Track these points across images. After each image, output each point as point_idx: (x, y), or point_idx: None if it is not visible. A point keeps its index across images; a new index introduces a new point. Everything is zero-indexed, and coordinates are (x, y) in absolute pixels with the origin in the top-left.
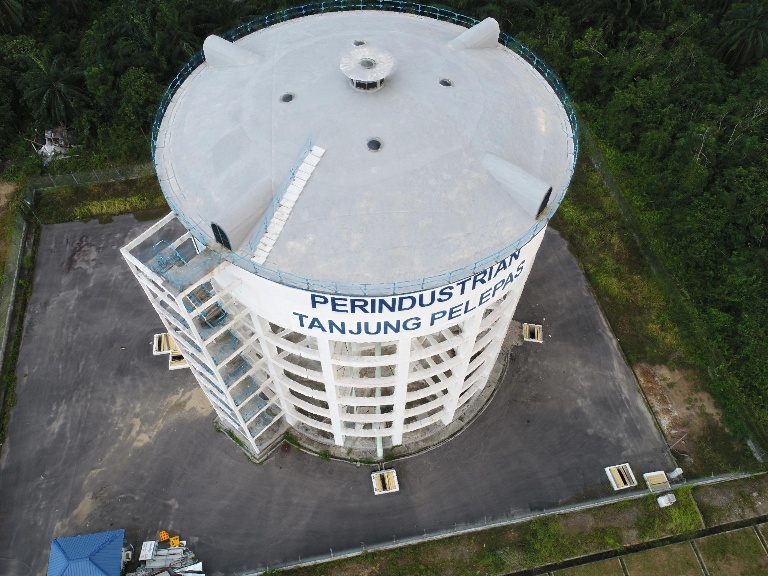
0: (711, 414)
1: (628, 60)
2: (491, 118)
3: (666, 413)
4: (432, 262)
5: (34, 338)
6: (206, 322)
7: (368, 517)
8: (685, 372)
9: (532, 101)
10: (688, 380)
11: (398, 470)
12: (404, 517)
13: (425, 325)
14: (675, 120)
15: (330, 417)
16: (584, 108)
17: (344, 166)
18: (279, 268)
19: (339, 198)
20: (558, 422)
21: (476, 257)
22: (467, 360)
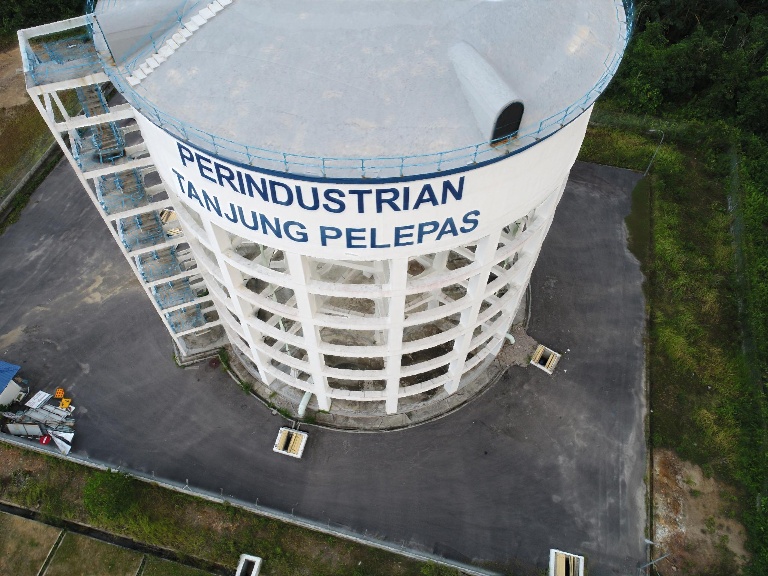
0: (733, 553)
1: None
2: (498, 7)
3: (669, 523)
4: (317, 145)
5: (63, 173)
6: (100, 155)
7: (254, 470)
8: (723, 486)
9: (580, 16)
10: (722, 498)
11: (312, 437)
12: (290, 488)
13: (315, 241)
14: None
15: (247, 340)
16: (747, 138)
17: (273, 2)
18: (147, 95)
19: (246, 35)
20: (522, 470)
21: (378, 160)
22: (398, 329)
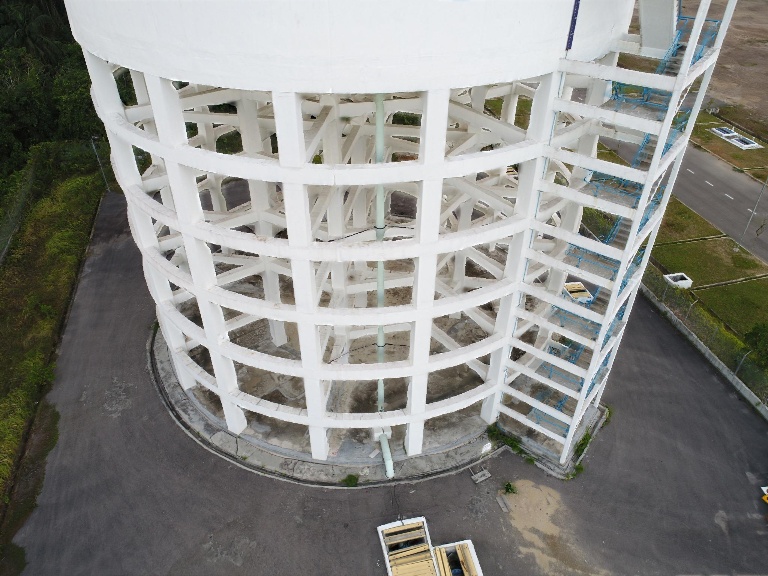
0: None
1: (6, 96)
2: None
3: None
4: None
5: None
6: (677, 48)
7: None
8: None
9: None
10: None
11: None
12: None
13: None
14: (122, 90)
15: None
16: None
17: None
18: None
19: None
20: None
21: None
22: None
